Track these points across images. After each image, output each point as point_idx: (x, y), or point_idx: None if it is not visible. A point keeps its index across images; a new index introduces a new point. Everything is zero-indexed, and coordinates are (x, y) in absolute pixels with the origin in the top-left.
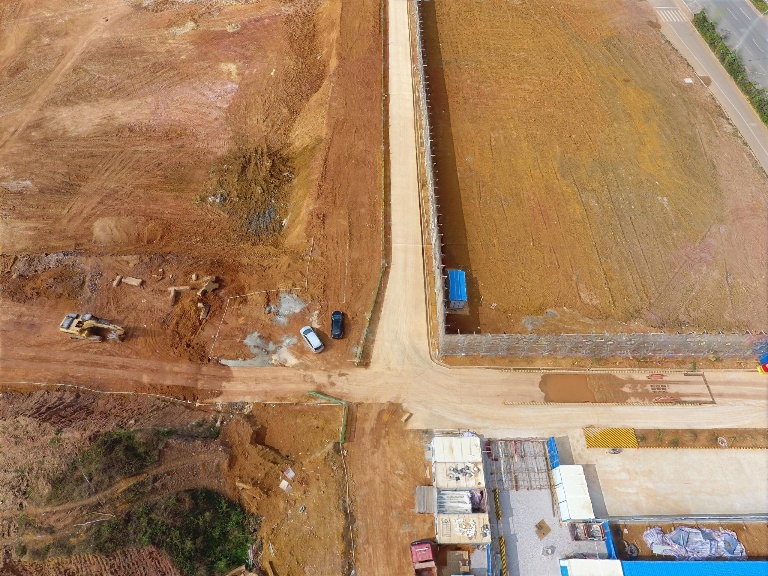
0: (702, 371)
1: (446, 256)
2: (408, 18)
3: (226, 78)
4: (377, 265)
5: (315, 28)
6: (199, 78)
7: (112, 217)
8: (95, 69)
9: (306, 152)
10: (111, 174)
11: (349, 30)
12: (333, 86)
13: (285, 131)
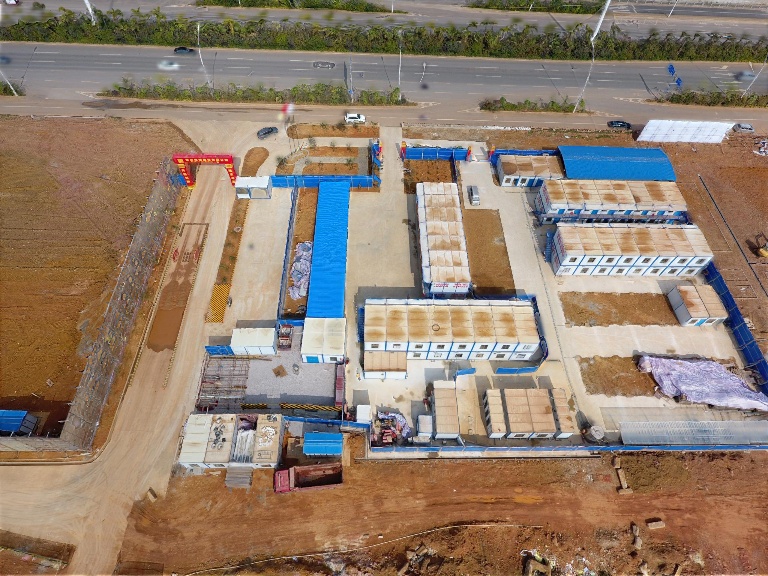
0: (181, 223)
1: None
2: None
3: None
4: None
5: None
6: None
7: None
8: None
9: None
10: None
11: None
12: None
13: None
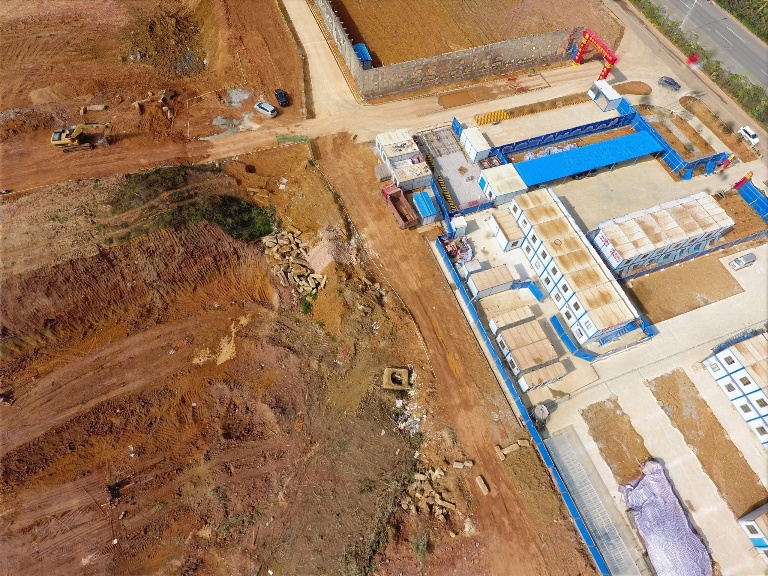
0: (539, 73)
1: None
2: None
3: None
4: (296, 59)
5: None
6: None
7: (44, 87)
8: None
9: (203, 4)
10: (24, 58)
11: None
12: None
13: None
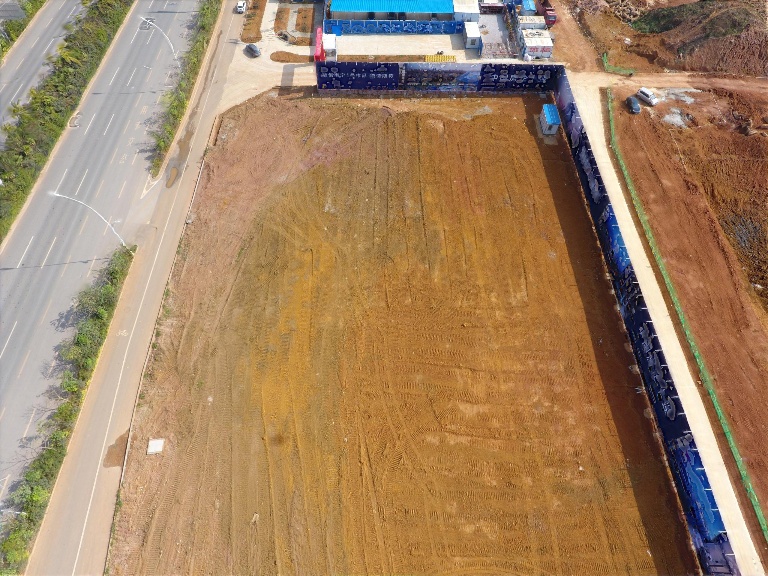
0: None
1: (559, 153)
2: None
3: None
4: (618, 146)
5: None
6: None
7: None
8: None
9: None
10: None
11: None
12: None
13: None
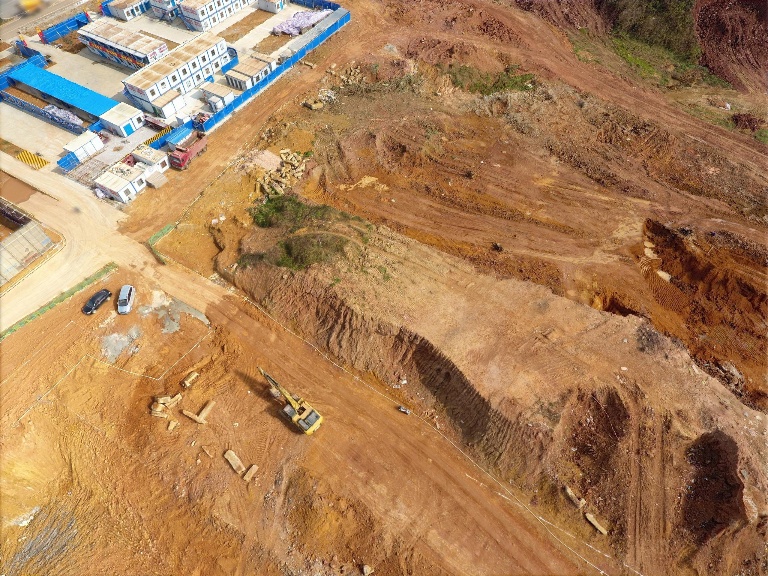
0: None
1: None
2: None
3: None
4: (5, 344)
5: None
6: None
7: None
8: None
9: None
10: None
11: None
12: None
13: None
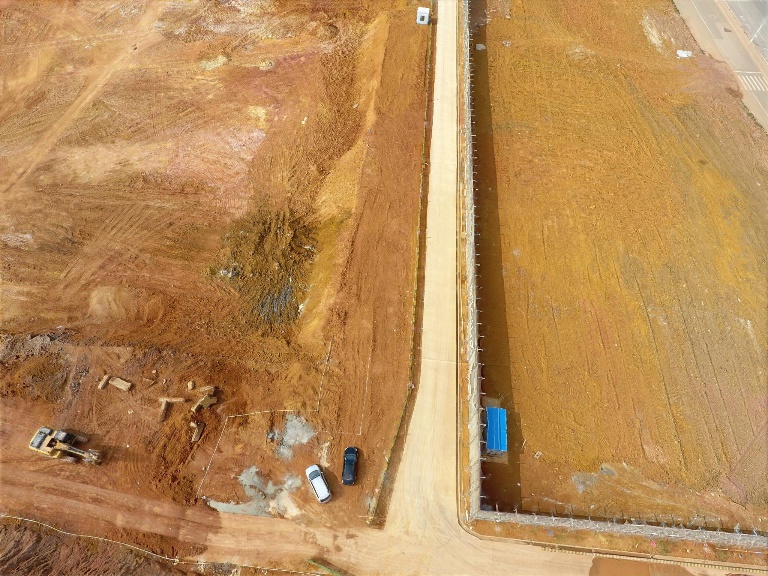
0: None
1: (484, 380)
2: (457, 69)
3: (253, 124)
4: (402, 386)
5: (354, 71)
6: (224, 122)
7: (112, 286)
8: (116, 105)
9: (332, 225)
10: (118, 233)
11: (391, 80)
12: (368, 147)
13: (311, 193)
